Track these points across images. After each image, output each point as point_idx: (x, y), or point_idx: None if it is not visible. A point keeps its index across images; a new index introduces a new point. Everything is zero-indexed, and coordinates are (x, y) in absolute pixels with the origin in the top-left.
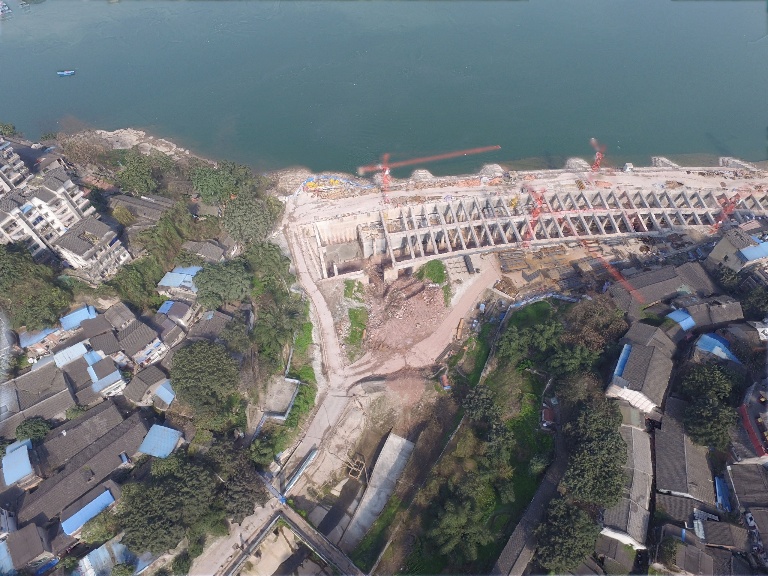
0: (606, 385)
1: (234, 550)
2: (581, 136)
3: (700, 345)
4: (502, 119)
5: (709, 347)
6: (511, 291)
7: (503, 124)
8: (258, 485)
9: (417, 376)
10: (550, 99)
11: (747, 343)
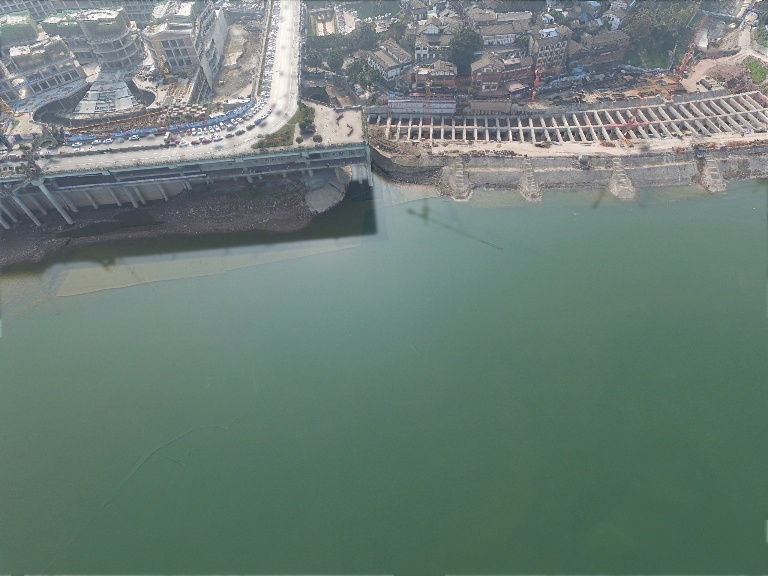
0: (634, 7)
1: (751, 12)
2: (621, 227)
3: (599, 4)
4: (734, 257)
5: (596, 2)
6: (671, 75)
7: (728, 250)
8: (760, 4)
9: (708, 54)
10: (673, 300)
11: (577, 6)
